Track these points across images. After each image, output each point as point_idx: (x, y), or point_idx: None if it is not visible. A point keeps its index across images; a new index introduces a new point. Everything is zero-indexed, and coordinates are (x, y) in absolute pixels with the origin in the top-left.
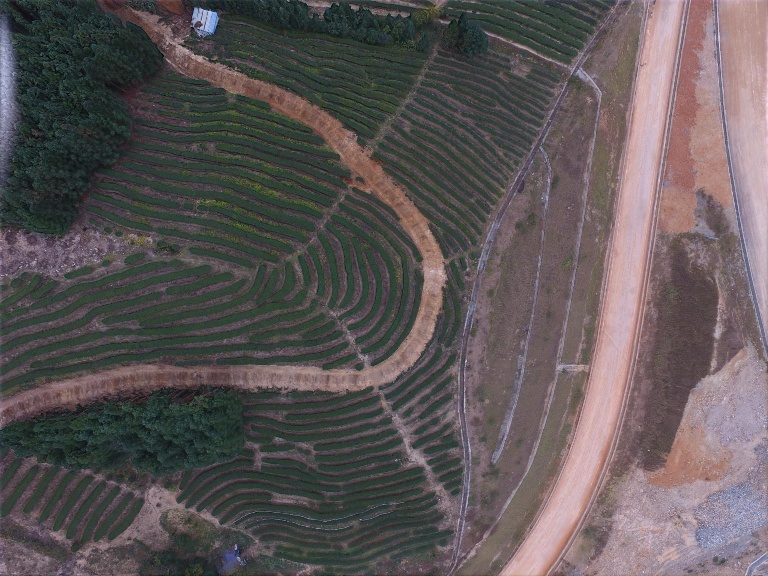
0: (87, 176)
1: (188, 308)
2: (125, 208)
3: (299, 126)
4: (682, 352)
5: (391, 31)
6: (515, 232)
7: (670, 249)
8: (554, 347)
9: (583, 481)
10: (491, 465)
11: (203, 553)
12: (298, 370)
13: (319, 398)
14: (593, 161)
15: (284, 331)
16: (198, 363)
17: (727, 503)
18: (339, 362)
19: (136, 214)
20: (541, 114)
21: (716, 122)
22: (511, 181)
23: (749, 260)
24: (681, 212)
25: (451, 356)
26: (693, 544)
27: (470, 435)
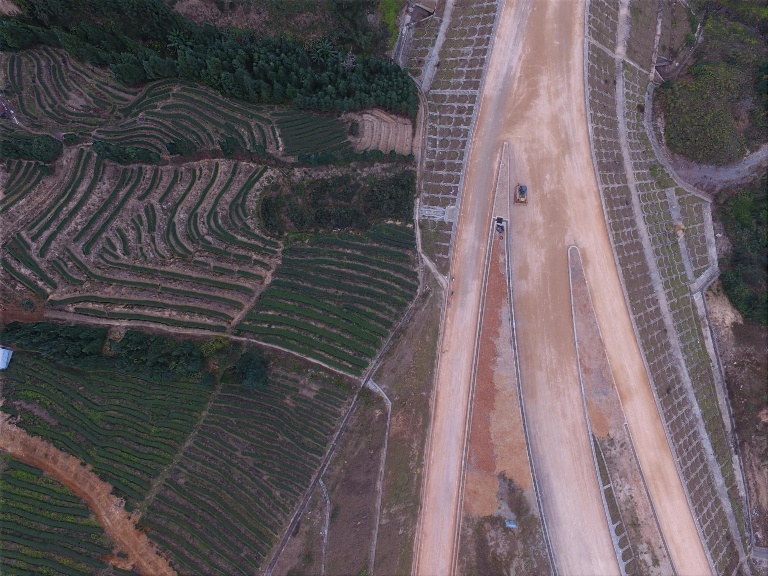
0: None
1: None
2: None
3: (65, 497)
4: None
5: None
6: None
7: (475, 532)
8: None
9: None
10: None
11: None
12: None
13: None
14: (385, 469)
15: None
16: None
17: None
18: None
19: None
20: (324, 440)
21: (514, 406)
22: (286, 524)
23: (550, 540)
24: (484, 495)
25: None
26: None
27: None
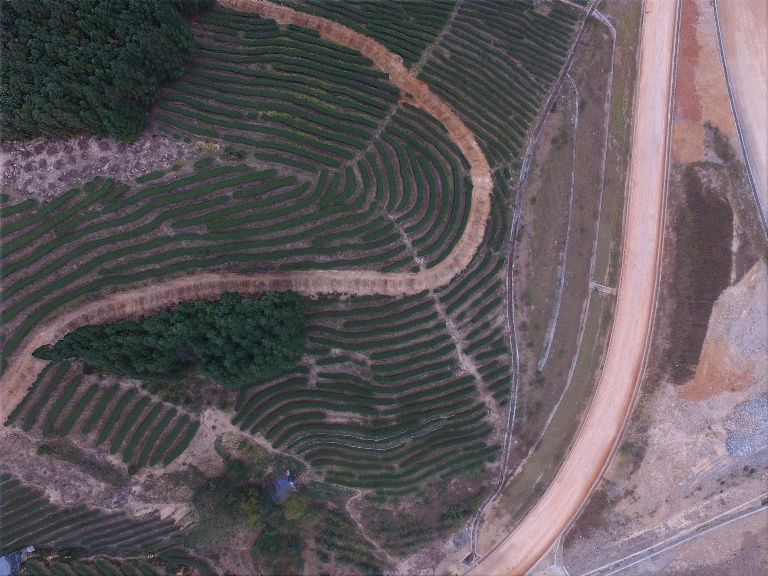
0: (157, 85)
1: (253, 212)
2: (192, 117)
3: (349, 50)
4: (702, 269)
5: None
6: (551, 147)
7: (684, 177)
8: (586, 265)
9: (617, 400)
10: (537, 373)
11: (256, 479)
12: (357, 275)
13: (377, 304)
14: (612, 92)
15: (346, 233)
16: (262, 268)
17: (753, 412)
18: (397, 264)
19: (203, 123)
20: (565, 46)
21: (716, 62)
22: (544, 102)
23: (755, 185)
24: (691, 143)
25: (500, 260)
26: (724, 454)
27: (518, 341)
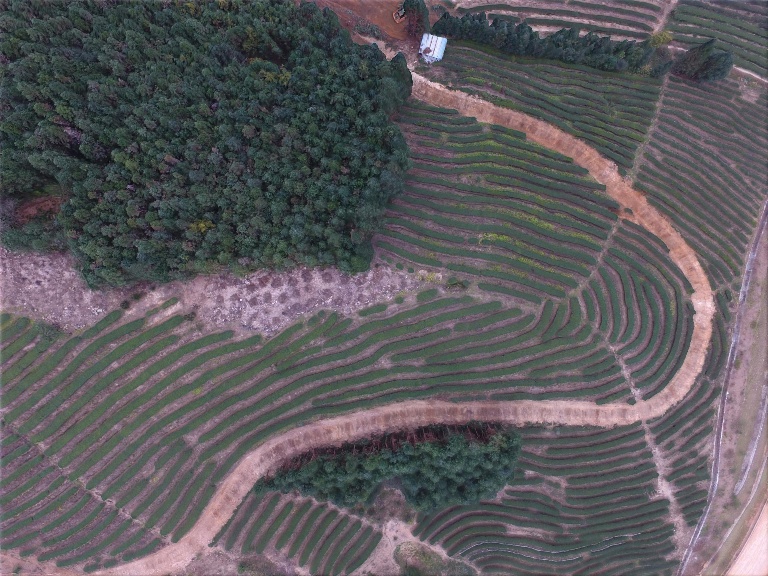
0: None
1: (472, 344)
2: (415, 244)
3: (561, 156)
4: None
5: (626, 57)
6: None
7: None
8: None
9: None
10: (734, 496)
11: None
12: (568, 404)
13: (584, 432)
14: None
15: (566, 367)
16: (474, 399)
17: None
18: (614, 397)
19: (424, 249)
20: None
21: None
22: (761, 210)
23: None
24: None
25: (717, 389)
26: None
27: (721, 467)
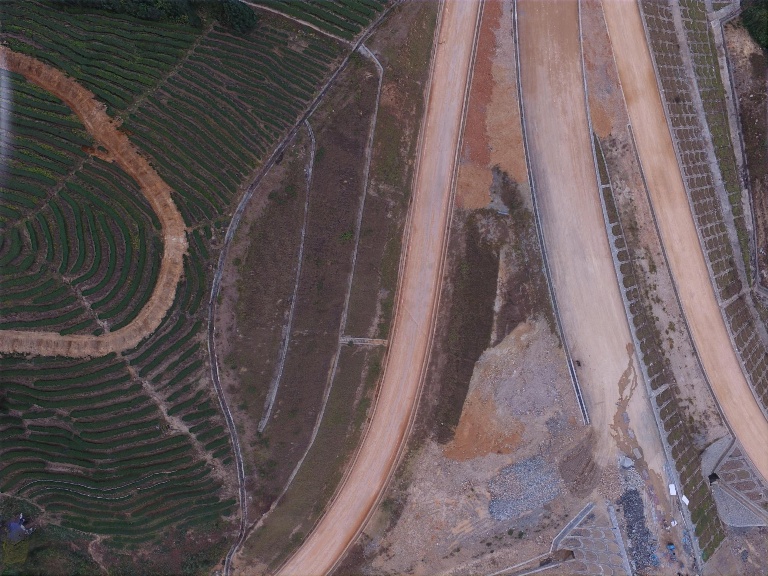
0: None
1: None
2: None
3: (47, 97)
4: (470, 326)
5: None
6: (269, 202)
7: (466, 225)
8: (336, 319)
9: (383, 455)
10: (257, 434)
11: None
12: (40, 336)
13: (65, 364)
14: (375, 136)
15: (14, 296)
16: None
17: (518, 476)
18: (75, 327)
19: None
20: (312, 88)
21: (512, 99)
22: (269, 153)
23: (543, 236)
24: (477, 188)
25: (196, 323)
26: (486, 517)
27: (228, 403)
